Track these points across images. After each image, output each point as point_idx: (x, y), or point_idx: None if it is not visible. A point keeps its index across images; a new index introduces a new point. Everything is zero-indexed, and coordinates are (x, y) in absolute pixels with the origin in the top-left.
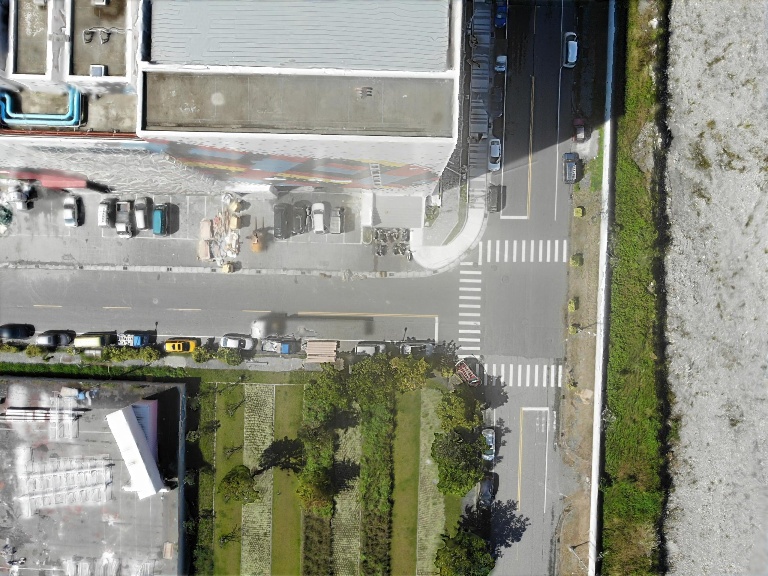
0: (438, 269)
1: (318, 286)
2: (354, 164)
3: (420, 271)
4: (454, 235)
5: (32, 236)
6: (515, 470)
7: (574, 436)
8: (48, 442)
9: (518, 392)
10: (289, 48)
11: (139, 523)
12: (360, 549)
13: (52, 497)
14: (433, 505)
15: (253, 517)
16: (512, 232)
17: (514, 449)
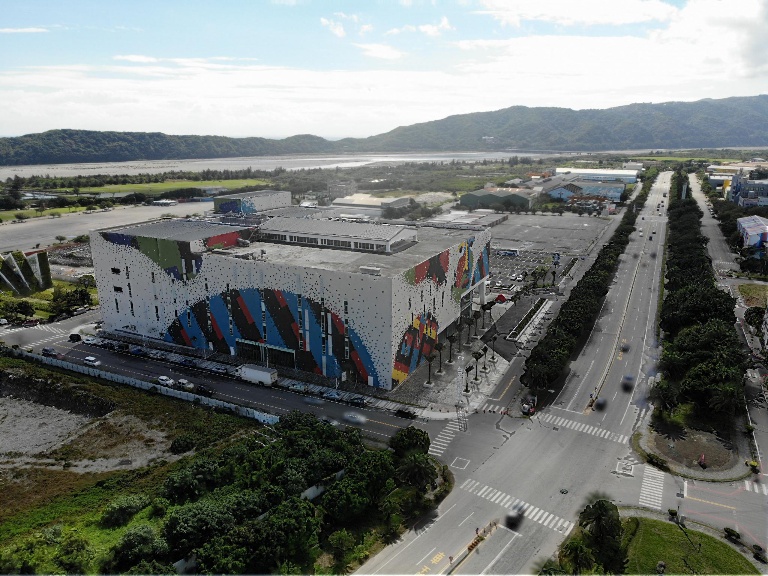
0: None
1: None
2: None
3: None
4: None
5: None
6: None
7: None
8: None
9: None
10: None
11: None
12: None
13: None
14: None
15: None
16: None
17: None
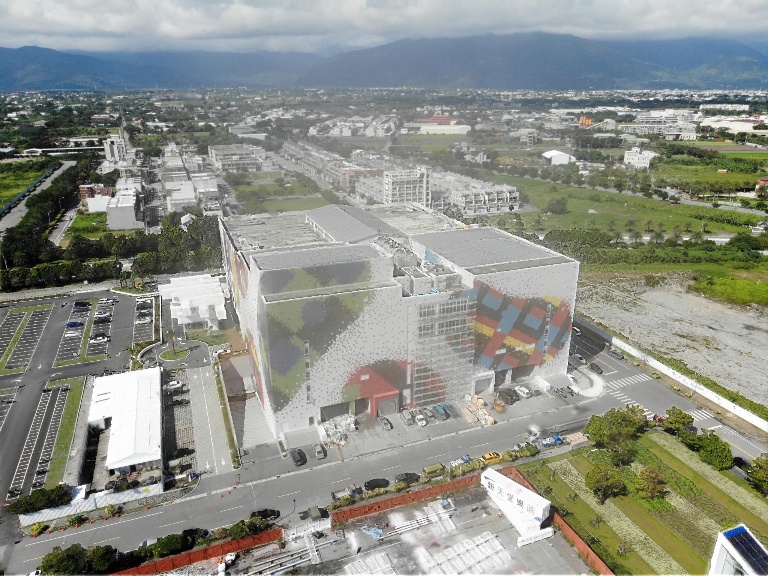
0: (599, 396)
1: (546, 417)
2: (541, 308)
3: (591, 399)
4: (592, 383)
5: (363, 441)
6: (745, 454)
7: (750, 431)
8: (437, 540)
9: (697, 424)
10: (507, 260)
11: (548, 568)
12: (716, 520)
13: (466, 571)
14: (726, 483)
15: (626, 531)
16: (617, 377)
17: (730, 446)
